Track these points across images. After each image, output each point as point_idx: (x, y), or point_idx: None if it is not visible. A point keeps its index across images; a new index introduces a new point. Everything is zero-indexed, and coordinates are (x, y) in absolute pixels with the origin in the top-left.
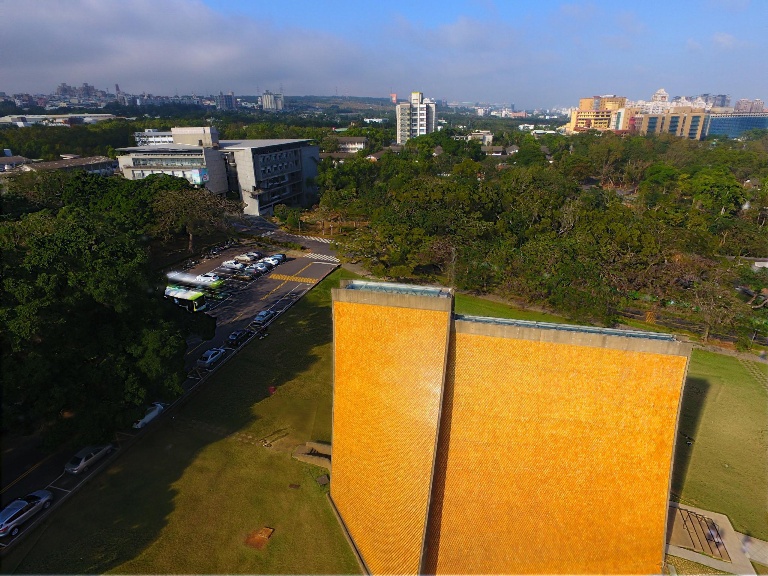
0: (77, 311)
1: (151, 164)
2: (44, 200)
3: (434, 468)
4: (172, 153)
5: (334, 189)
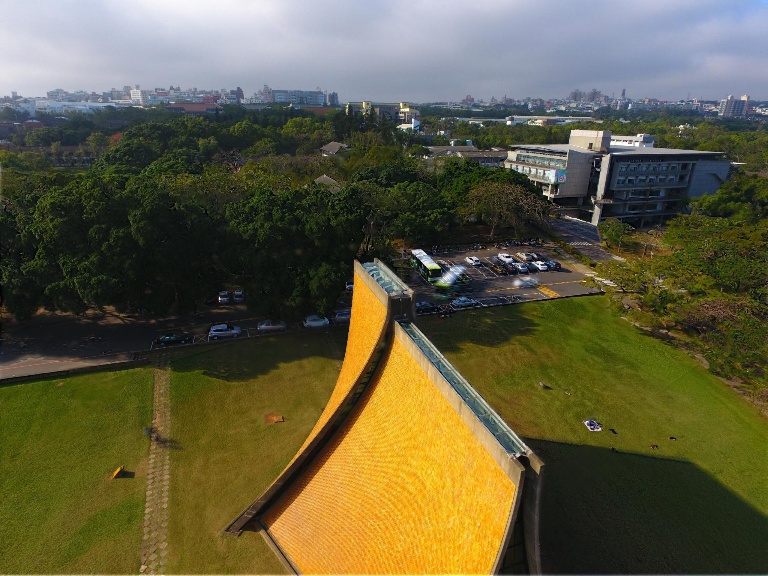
0: (296, 236)
1: (528, 161)
2: (427, 177)
3: (319, 432)
4: (547, 153)
5: (697, 214)
